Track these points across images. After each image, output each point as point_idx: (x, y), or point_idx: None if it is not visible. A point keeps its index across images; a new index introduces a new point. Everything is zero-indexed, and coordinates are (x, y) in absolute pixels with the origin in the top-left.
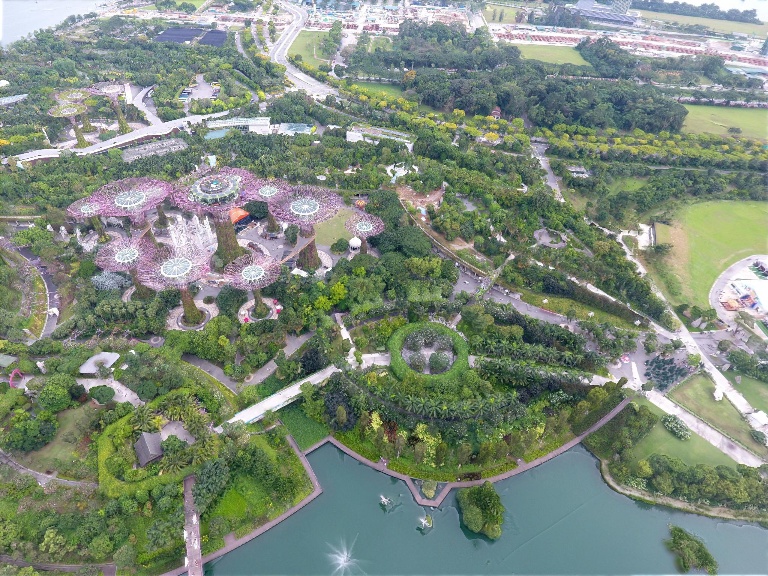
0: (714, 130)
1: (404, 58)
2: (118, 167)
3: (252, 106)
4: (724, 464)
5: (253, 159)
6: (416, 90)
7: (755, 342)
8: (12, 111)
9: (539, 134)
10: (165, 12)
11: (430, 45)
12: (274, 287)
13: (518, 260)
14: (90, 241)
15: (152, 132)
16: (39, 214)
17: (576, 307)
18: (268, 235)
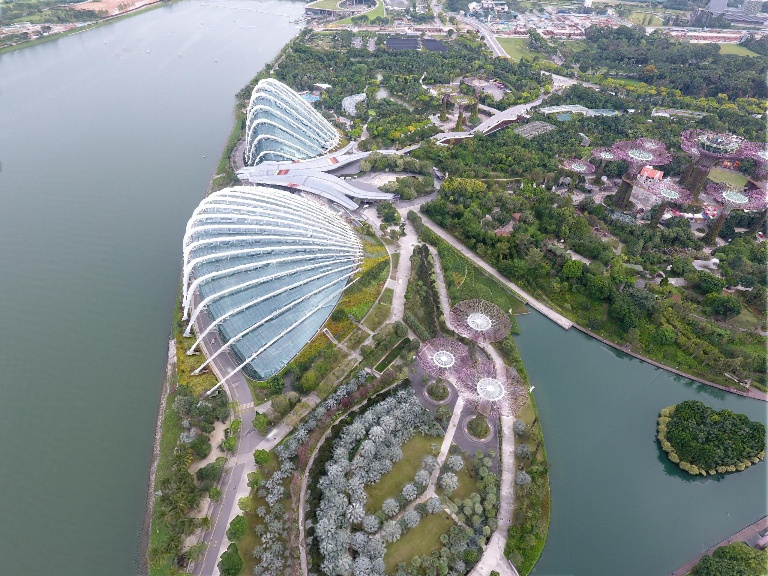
0: None
1: (624, 56)
2: (528, 142)
3: (559, 96)
4: None
5: (615, 134)
6: (669, 80)
7: None
8: (367, 106)
9: None
10: (360, 26)
11: (625, 45)
12: (749, 219)
13: None
14: None
15: (504, 118)
16: (511, 177)
17: None
18: None
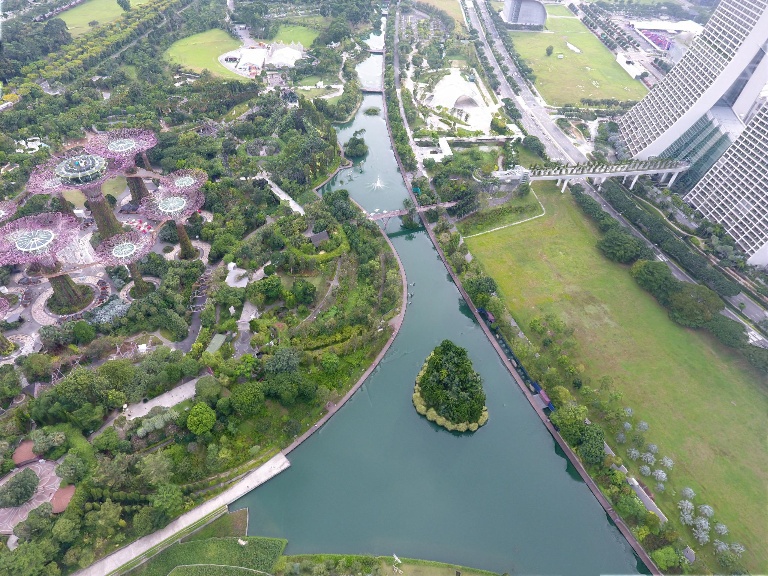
0: (79, 31)
1: None
2: None
3: None
4: (339, 98)
5: None
6: None
7: (286, 67)
8: None
9: (28, 79)
10: None
11: None
12: None
13: (200, 108)
14: (0, 365)
15: None
16: None
17: (241, 107)
18: (87, 222)
